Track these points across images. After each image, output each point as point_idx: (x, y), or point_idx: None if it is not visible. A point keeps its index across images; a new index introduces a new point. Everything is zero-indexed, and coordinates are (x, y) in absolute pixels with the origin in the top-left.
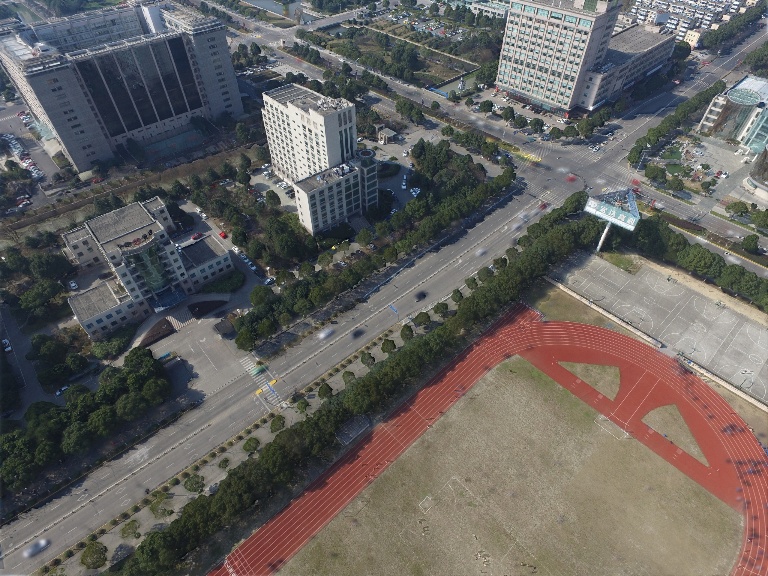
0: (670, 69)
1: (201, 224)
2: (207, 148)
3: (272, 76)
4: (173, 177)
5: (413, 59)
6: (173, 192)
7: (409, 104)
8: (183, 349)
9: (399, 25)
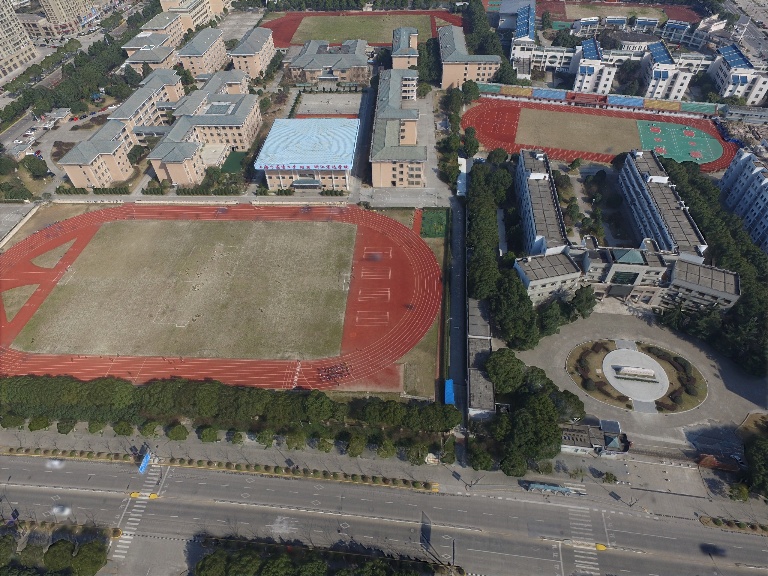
0: None
1: None
2: None
3: None
4: None
5: None
6: None
7: None
8: None
9: None
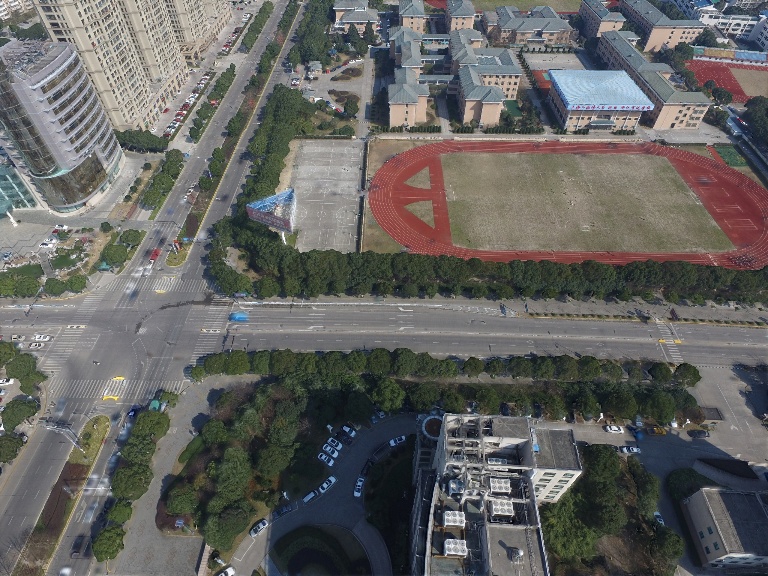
0: None
1: None
2: None
3: None
4: None
5: None
6: None
7: None
8: (760, 432)
9: None
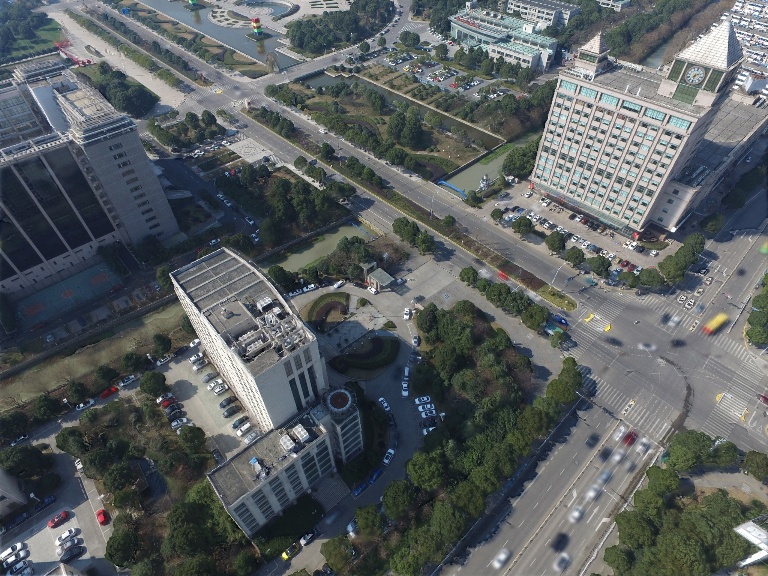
0: (767, 154)
1: (72, 484)
2: (116, 300)
3: (228, 160)
4: (41, 383)
5: (416, 136)
6: (38, 413)
7: (412, 227)
8: None
9: (398, 73)
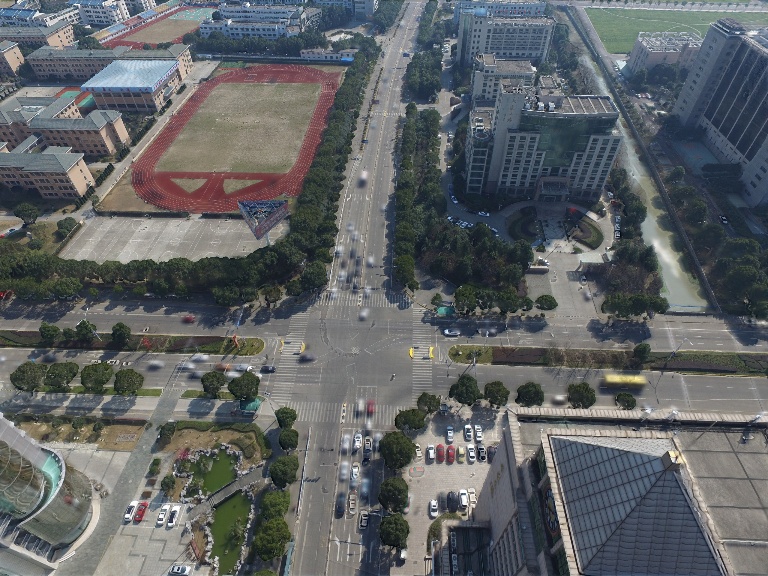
0: None
1: None
2: None
3: None
4: None
5: None
6: None
7: (640, 294)
8: (437, 105)
9: None
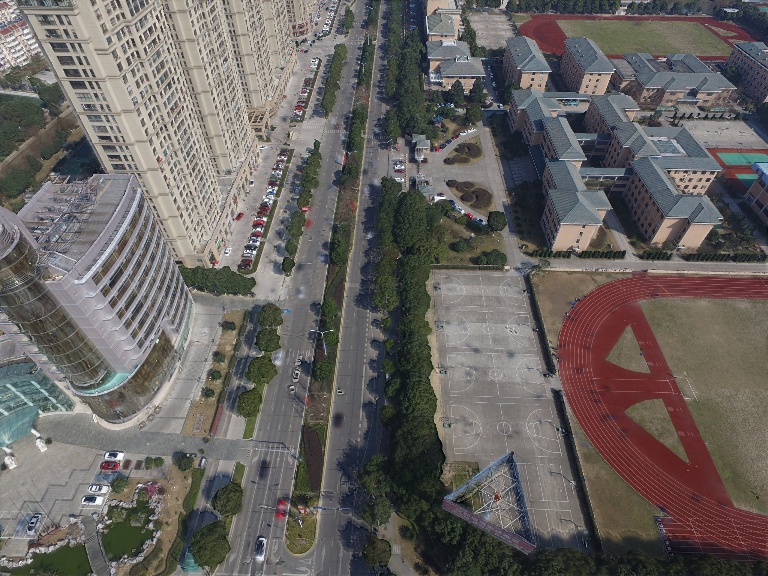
0: None
1: None
2: None
3: None
4: None
5: None
6: None
7: None
8: None
9: None
